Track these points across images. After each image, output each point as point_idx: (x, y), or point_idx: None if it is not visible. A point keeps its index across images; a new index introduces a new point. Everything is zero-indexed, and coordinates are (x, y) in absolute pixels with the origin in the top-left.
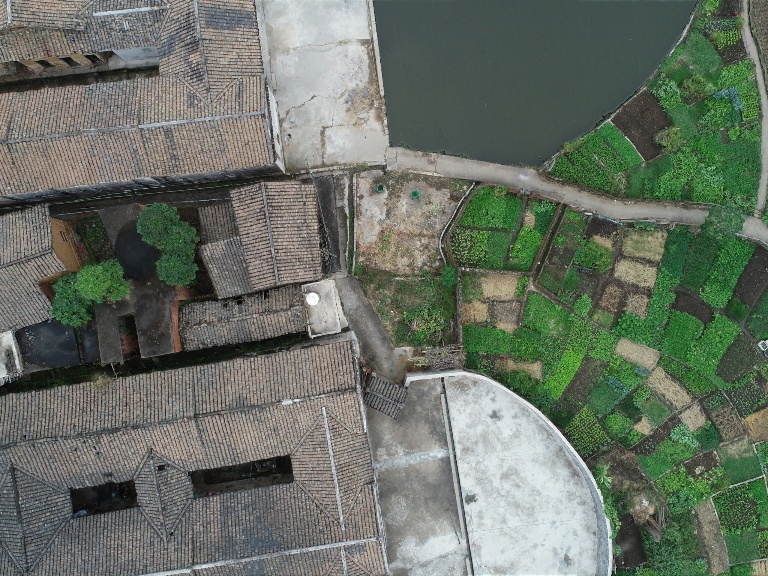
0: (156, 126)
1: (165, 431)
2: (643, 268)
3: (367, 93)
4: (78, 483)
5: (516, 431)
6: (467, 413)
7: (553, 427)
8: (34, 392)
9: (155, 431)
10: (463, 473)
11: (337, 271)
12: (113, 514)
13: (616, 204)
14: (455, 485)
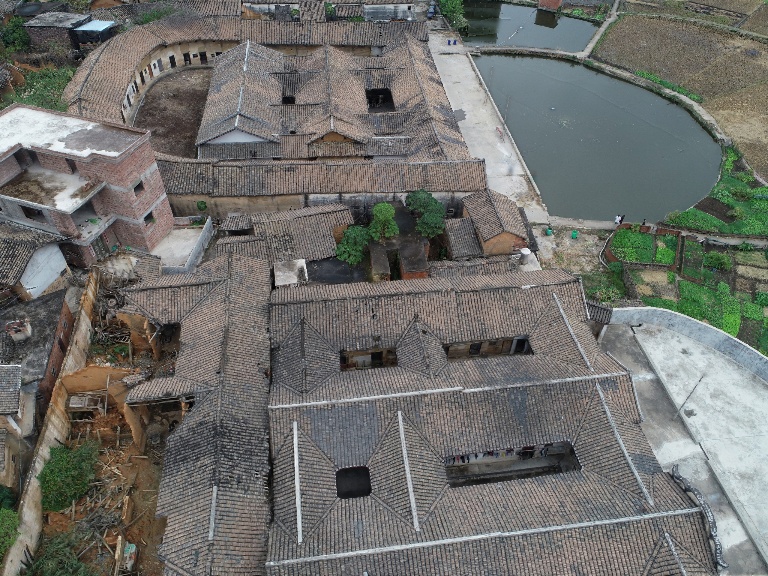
0: (418, 163)
1: (431, 300)
2: (757, 269)
3: (528, 194)
4: (350, 345)
5: (708, 363)
6: (661, 350)
7: (741, 342)
8: (321, 285)
9: (423, 299)
10: (674, 393)
11: (536, 249)
12: (379, 369)
13: (719, 238)
14: (671, 397)
